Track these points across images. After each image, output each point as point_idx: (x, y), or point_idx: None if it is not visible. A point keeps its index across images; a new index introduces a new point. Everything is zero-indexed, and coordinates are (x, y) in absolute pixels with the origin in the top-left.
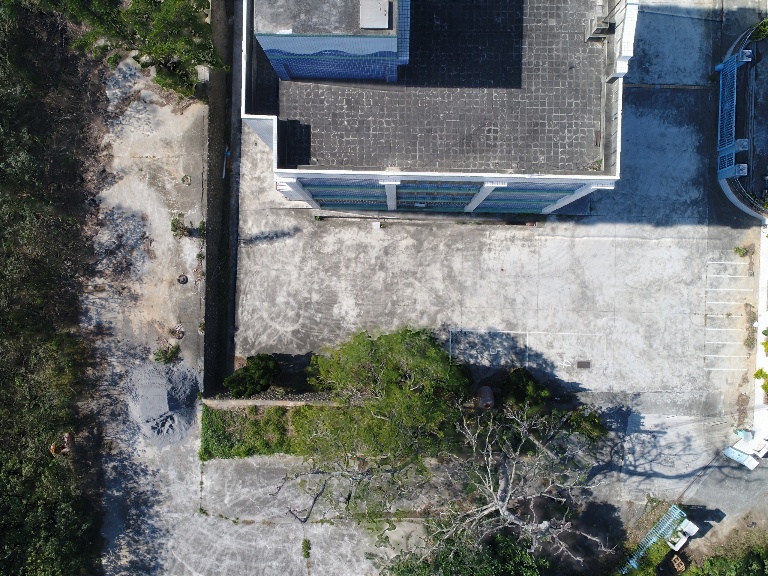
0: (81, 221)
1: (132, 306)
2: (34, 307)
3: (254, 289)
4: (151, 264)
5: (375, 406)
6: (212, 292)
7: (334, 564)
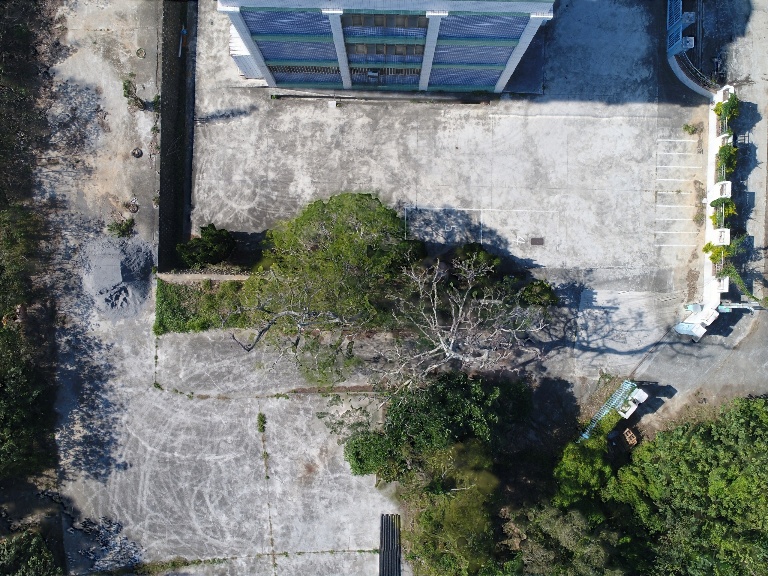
0: (34, 93)
1: (86, 179)
2: None
3: (210, 167)
4: (105, 137)
5: None
6: (167, 168)
7: (289, 438)
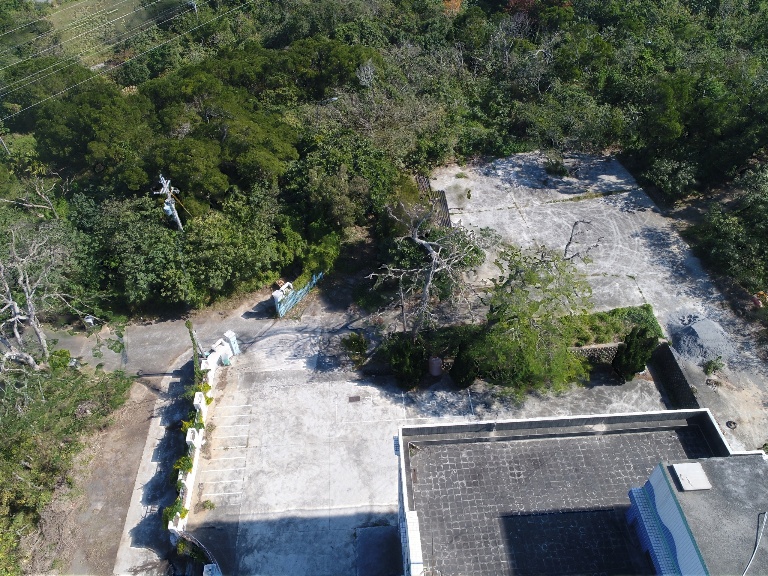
0: None
1: (765, 400)
2: None
3: None
4: None
5: None
6: None
7: None
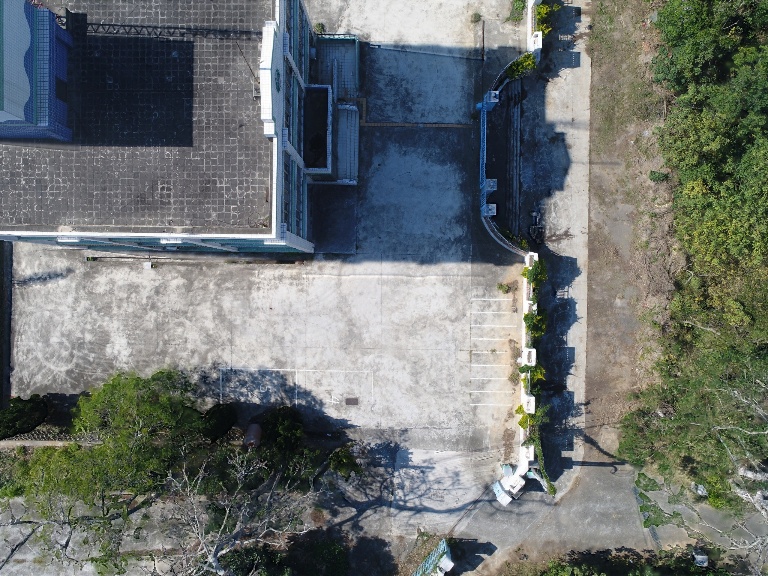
0: None
1: None
2: None
3: (28, 330)
4: None
5: None
6: None
7: None
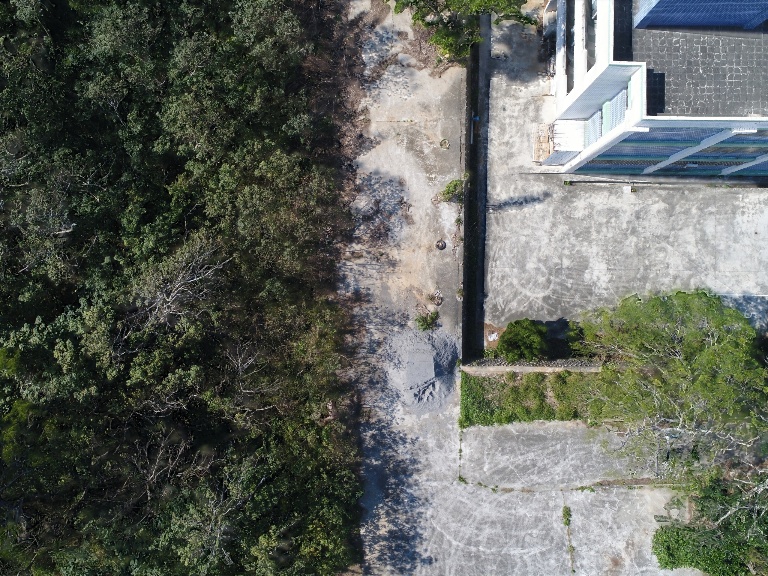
0: (339, 186)
1: (390, 272)
2: (294, 274)
3: (503, 255)
4: (409, 230)
5: (634, 371)
6: (465, 258)
7: (595, 531)
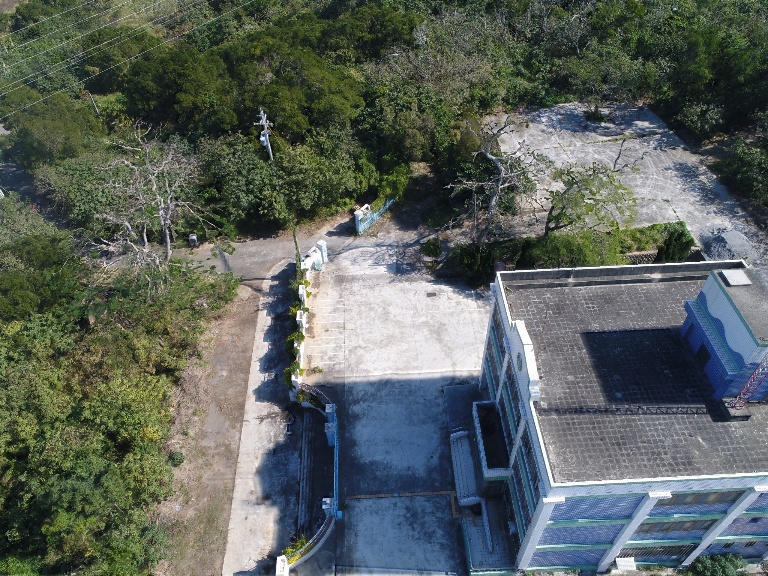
0: None
1: None
2: None
3: None
4: None
5: None
6: None
7: None
